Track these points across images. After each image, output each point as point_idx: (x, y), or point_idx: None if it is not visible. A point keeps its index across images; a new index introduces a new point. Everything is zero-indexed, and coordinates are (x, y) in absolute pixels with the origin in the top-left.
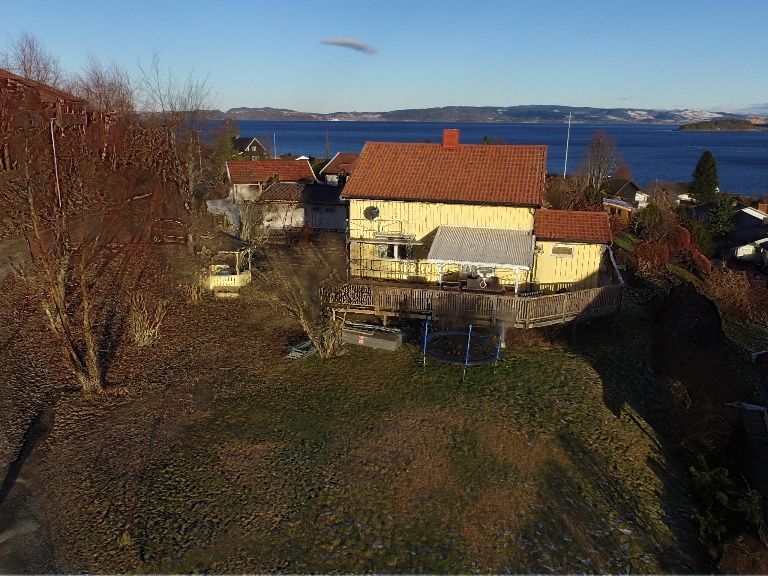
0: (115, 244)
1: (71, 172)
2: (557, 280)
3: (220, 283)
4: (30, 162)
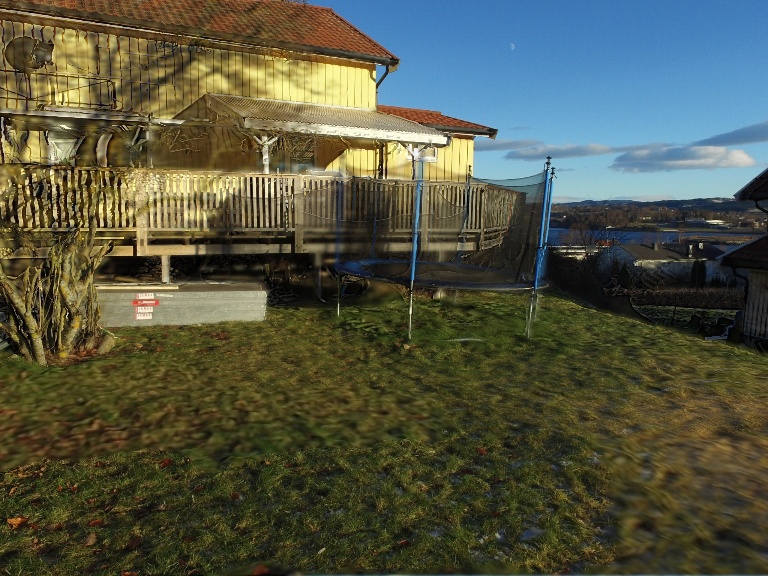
0: None
1: None
2: None
3: None
4: None
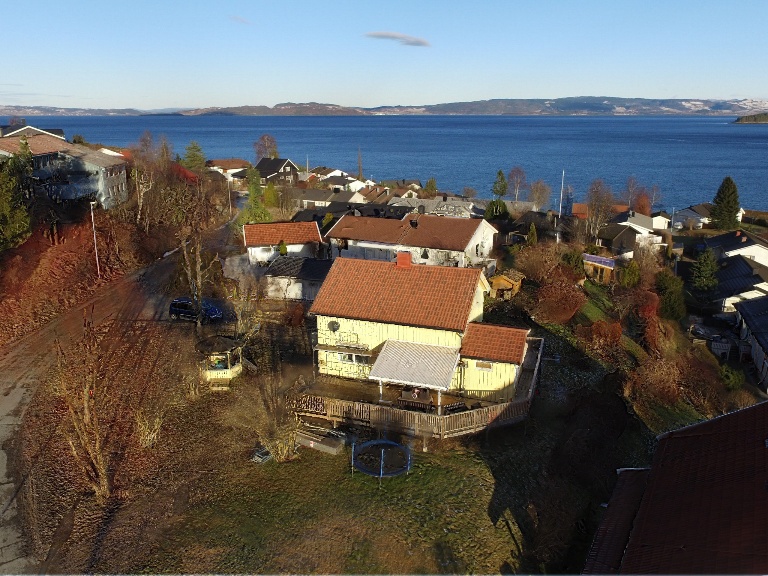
0: (139, 323)
1: (109, 241)
2: (481, 388)
3: (215, 376)
4: (74, 237)
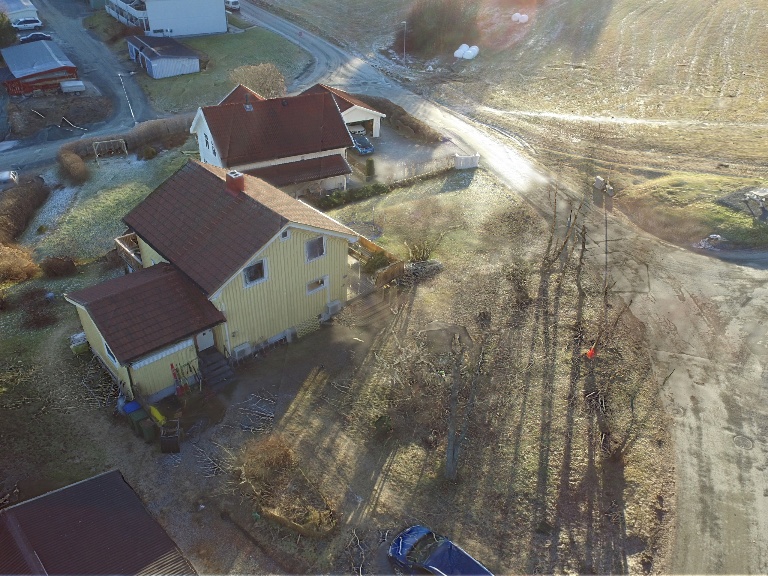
0: None
1: None
2: None
3: None
4: None
